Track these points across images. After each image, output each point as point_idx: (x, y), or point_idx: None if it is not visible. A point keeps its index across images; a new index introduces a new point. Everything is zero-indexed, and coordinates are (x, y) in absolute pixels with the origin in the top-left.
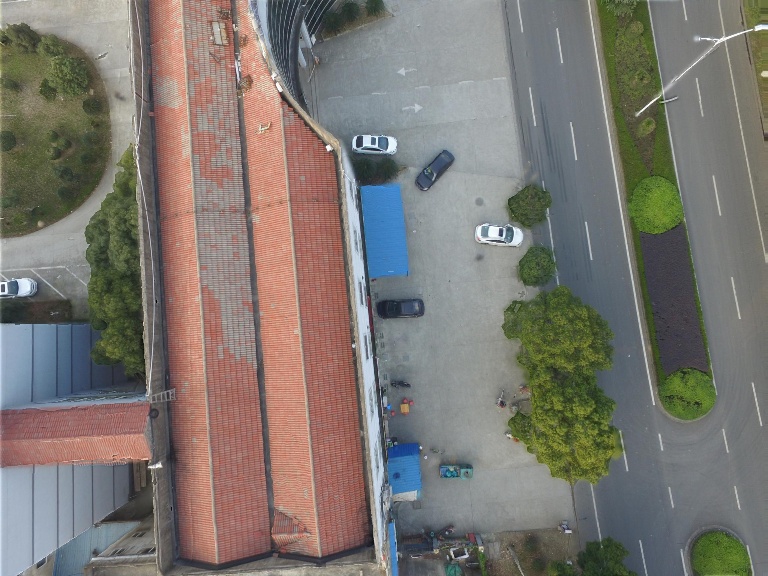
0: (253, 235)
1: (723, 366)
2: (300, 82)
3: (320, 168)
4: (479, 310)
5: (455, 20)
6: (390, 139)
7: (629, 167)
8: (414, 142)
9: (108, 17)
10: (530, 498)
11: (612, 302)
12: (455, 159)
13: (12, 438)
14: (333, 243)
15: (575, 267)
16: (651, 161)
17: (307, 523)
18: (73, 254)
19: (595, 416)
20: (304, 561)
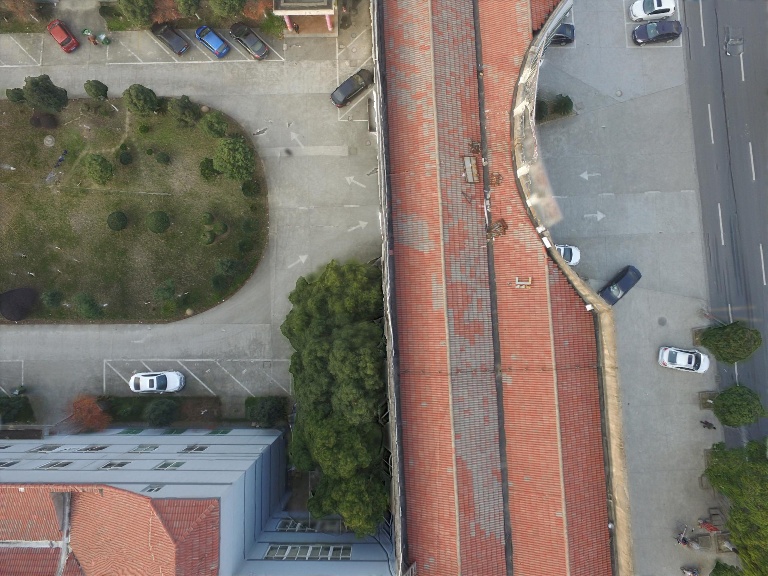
0: (503, 397)
1: None
2: None
3: (581, 330)
4: (659, 437)
5: (642, 124)
6: (574, 250)
7: None
8: (595, 252)
9: (268, 89)
10: None
11: None
12: (641, 275)
13: None
14: (592, 413)
15: (760, 398)
16: None
17: None
18: (224, 347)
19: None
20: None
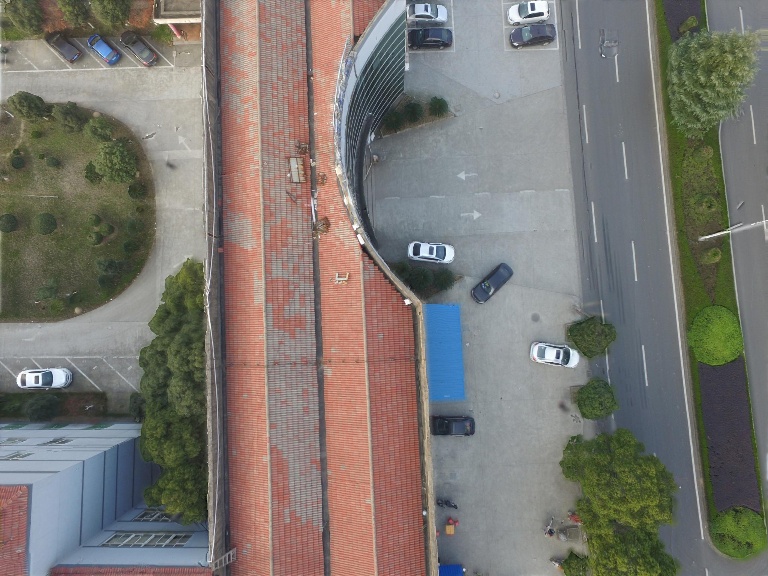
0: (324, 388)
1: None
2: (364, 196)
3: (398, 324)
4: (530, 430)
5: (519, 125)
6: (448, 248)
7: (690, 294)
8: (471, 250)
9: (157, 95)
10: None
11: (669, 438)
12: (513, 272)
13: None
14: (408, 404)
15: (630, 392)
16: (713, 290)
17: None
18: (111, 344)
19: None
20: None
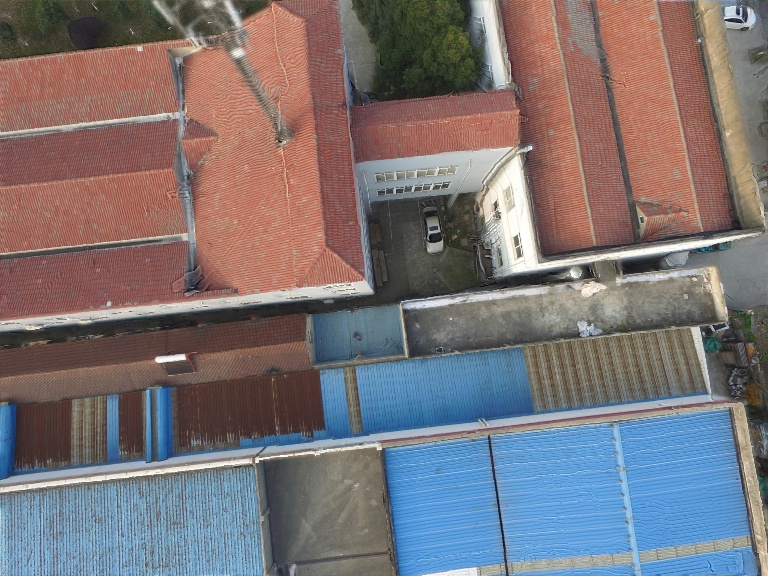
0: None
1: None
2: None
3: None
4: None
5: None
6: None
7: None
8: None
9: None
10: None
11: None
12: None
13: (377, 123)
14: None
15: None
16: None
17: (681, 204)
18: None
19: None
20: (687, 237)
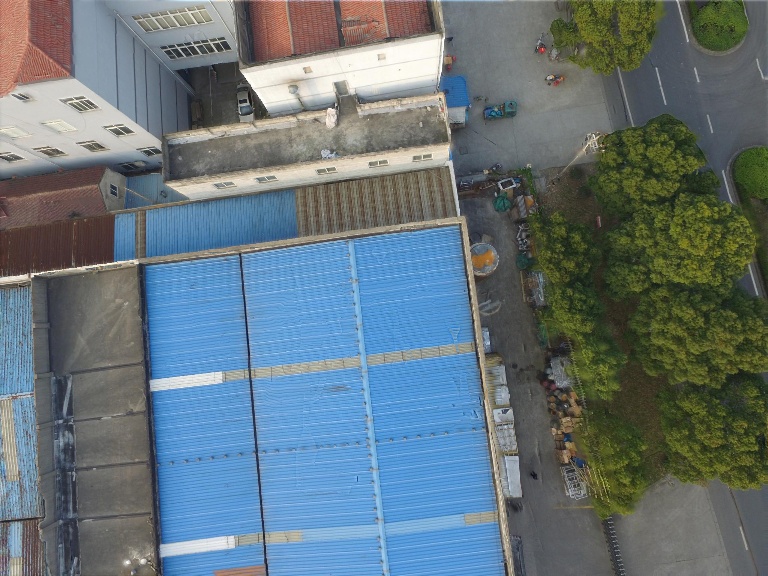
0: None
1: (753, 0)
2: None
3: None
4: None
5: None
6: None
7: None
8: None
9: None
10: (572, 136)
11: None
12: None
13: None
14: None
15: None
16: None
17: (375, 16)
18: None
19: None
20: None
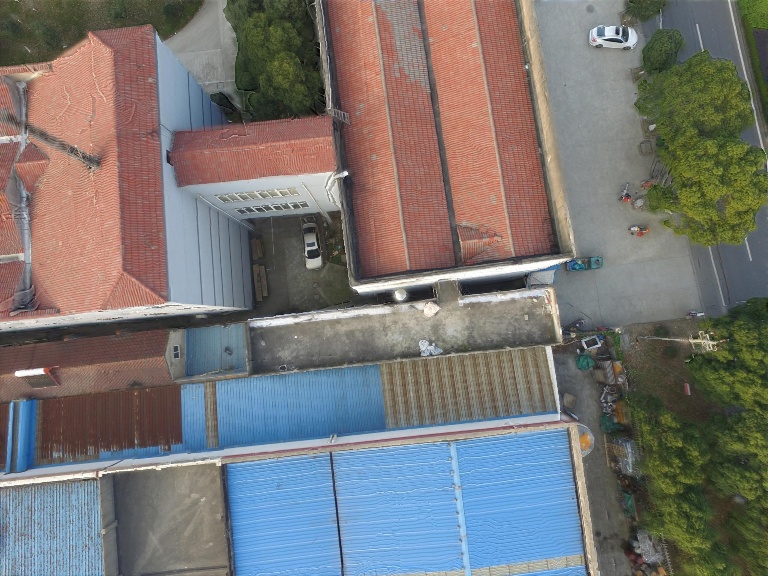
0: None
1: None
2: None
3: None
4: (596, 111)
5: None
6: None
7: None
8: None
9: None
10: (656, 291)
11: None
12: None
13: (195, 149)
14: None
15: None
16: None
17: (496, 229)
18: None
19: (751, 155)
20: (498, 262)
